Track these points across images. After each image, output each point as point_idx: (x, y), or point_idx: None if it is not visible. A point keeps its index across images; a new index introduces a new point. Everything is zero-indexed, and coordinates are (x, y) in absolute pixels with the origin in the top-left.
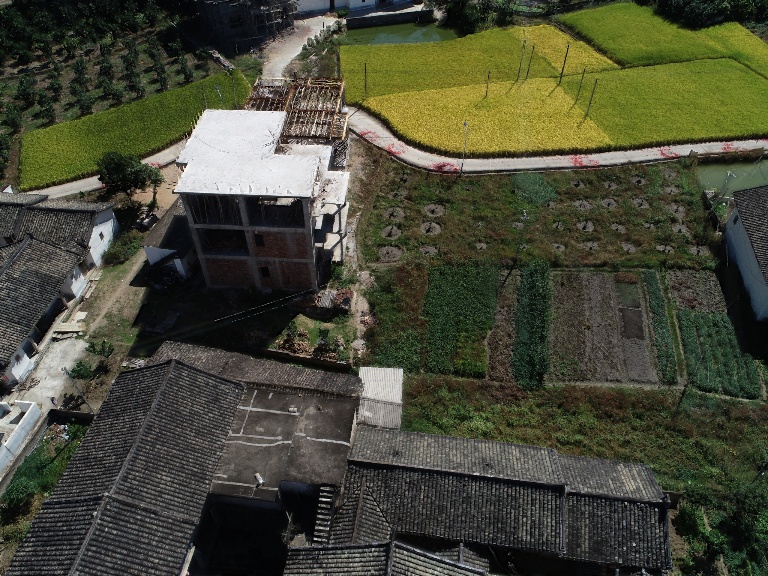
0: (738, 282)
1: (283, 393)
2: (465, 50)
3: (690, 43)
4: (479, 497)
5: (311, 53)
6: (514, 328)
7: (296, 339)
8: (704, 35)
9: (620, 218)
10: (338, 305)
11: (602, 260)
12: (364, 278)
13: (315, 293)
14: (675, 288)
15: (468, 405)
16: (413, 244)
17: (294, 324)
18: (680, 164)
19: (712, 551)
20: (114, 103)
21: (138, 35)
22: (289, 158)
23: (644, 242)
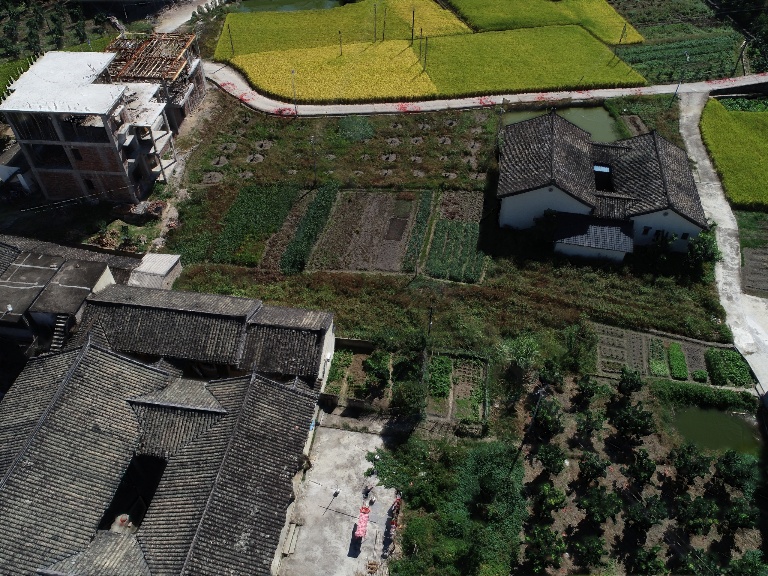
0: (498, 199)
1: (51, 255)
2: (339, 17)
3: (546, 12)
4: (181, 326)
5: (199, 19)
6: (295, 232)
7: (108, 237)
8: (563, 5)
9: (416, 150)
10: (149, 212)
11: (389, 182)
12: (181, 194)
13: (135, 204)
14: (444, 204)
15: (231, 283)
16: (234, 170)
17: (104, 223)
18: (493, 110)
19: (383, 380)
20: (12, 59)
21: (50, 4)
22: (101, 86)
23: (432, 169)
